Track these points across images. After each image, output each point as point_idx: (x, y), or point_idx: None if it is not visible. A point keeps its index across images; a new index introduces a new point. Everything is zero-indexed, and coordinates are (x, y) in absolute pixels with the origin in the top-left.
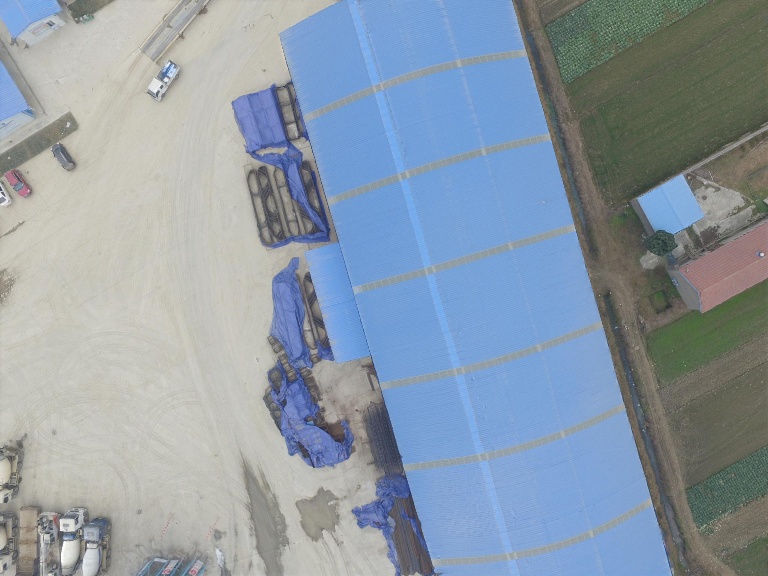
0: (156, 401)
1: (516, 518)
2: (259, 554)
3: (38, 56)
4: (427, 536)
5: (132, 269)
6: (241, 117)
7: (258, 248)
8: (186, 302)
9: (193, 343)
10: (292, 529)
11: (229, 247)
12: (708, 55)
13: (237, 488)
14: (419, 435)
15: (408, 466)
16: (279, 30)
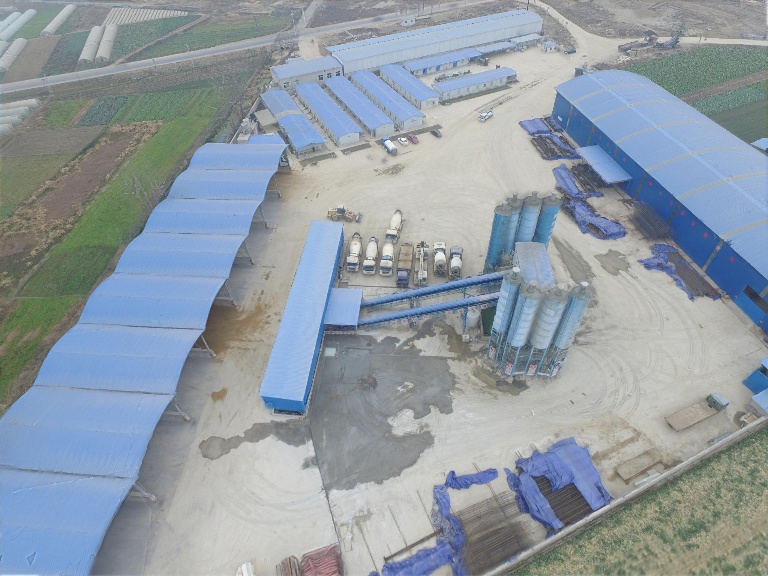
0: (489, 209)
1: (767, 201)
2: (574, 281)
3: (424, 112)
4: (709, 225)
5: (471, 165)
6: (525, 125)
7: (541, 160)
8: (503, 176)
9: (509, 189)
10: (595, 269)
11: (525, 160)
12: (754, 116)
13: (549, 247)
14: (680, 182)
15: (679, 197)
16: (537, 108)
